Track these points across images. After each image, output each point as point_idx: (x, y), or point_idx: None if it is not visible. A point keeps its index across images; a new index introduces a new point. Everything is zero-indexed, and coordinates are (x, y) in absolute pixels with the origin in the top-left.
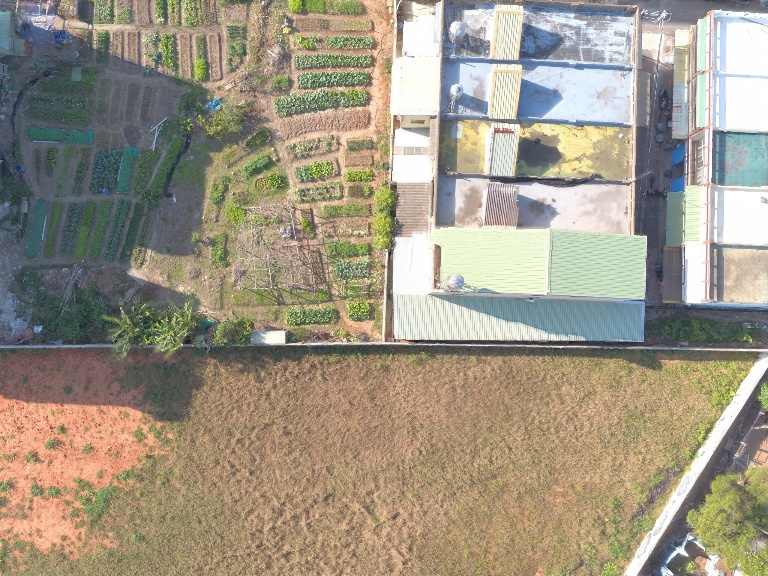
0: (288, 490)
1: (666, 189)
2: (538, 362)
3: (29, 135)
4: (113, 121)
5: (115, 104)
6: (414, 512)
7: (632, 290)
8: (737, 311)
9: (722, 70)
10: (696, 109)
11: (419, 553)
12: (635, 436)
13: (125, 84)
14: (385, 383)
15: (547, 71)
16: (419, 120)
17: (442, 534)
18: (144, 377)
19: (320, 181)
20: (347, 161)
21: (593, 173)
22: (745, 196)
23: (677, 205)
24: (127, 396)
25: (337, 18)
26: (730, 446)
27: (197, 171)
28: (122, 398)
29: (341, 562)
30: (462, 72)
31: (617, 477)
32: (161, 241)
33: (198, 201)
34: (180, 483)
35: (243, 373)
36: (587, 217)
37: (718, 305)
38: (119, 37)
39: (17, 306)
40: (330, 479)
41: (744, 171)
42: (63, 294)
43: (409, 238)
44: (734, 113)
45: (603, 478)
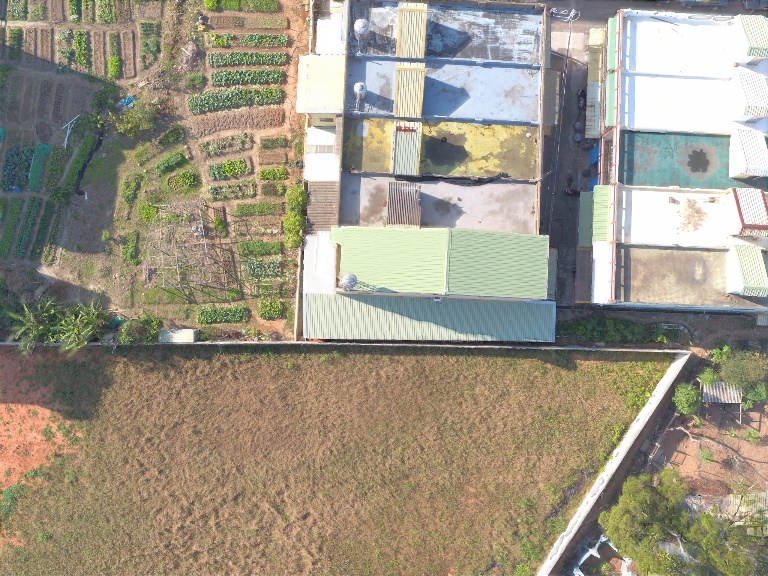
0: (197, 489)
1: (584, 189)
2: (451, 362)
3: None
4: (25, 118)
5: (27, 101)
6: (324, 512)
7: (533, 290)
8: (654, 312)
9: (631, 69)
10: (605, 108)
11: (329, 553)
12: (549, 437)
13: (37, 81)
14: (297, 382)
15: (454, 69)
16: (327, 118)
17: (353, 534)
18: (53, 375)
19: (233, 179)
20: (261, 159)
21: (500, 172)
22: (653, 196)
23: (589, 205)
24: (36, 394)
25: (252, 16)
26: (646, 447)
27: (109, 169)
28: (31, 396)
29: (250, 562)
30: (368, 70)
31: (530, 478)
32: (72, 239)
33: (110, 199)
34: (88, 482)
35: (153, 372)
36: (493, 216)
37: (632, 305)
38: (32, 34)
39: None
40: (240, 478)
41: (653, 171)
42: None
43: None
44: (643, 112)
45: (516, 479)
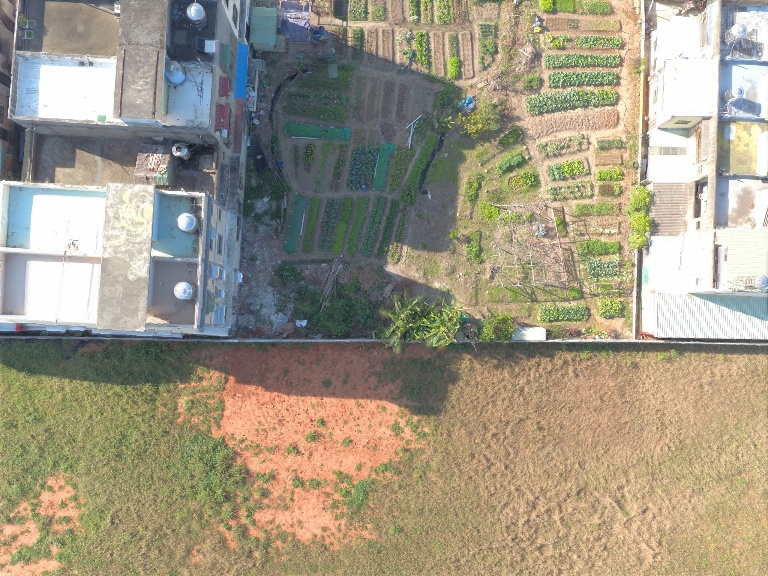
0: (542, 484)
1: None
2: None
3: (288, 131)
4: (369, 118)
5: (371, 101)
6: (663, 507)
7: None
8: None
9: None
10: None
11: (668, 547)
12: None
13: (380, 81)
14: (634, 380)
15: None
16: (686, 121)
17: (690, 529)
18: (401, 372)
19: (571, 180)
20: (597, 160)
21: None
22: None
23: None
24: (384, 390)
25: (586, 18)
26: None
27: (451, 168)
28: (379, 392)
29: (594, 555)
30: (735, 74)
31: None
32: (417, 237)
33: (452, 198)
34: (437, 476)
35: (498, 369)
36: None
37: None
38: (373, 34)
39: (277, 300)
40: (582, 474)
41: None
42: (323, 289)
43: (666, 237)
44: None
45: None
